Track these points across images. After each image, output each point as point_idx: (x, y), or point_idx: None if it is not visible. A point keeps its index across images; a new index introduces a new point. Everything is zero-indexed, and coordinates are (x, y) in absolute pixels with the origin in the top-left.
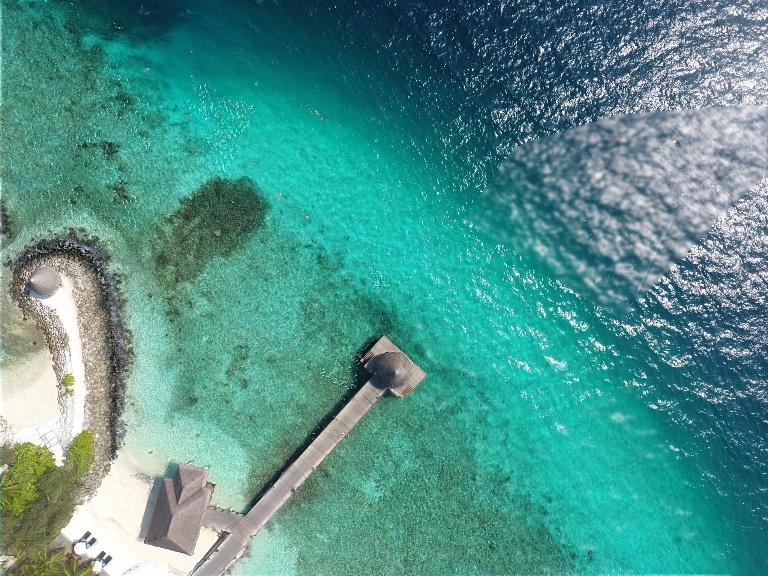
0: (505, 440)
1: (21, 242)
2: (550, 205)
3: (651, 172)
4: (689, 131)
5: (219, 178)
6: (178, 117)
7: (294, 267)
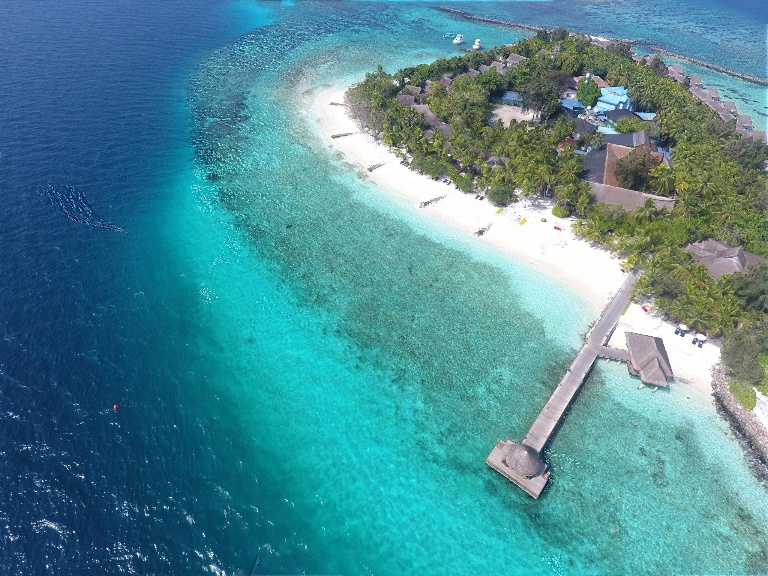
0: (398, 410)
1: None
2: None
3: None
4: None
5: None
6: None
7: (654, 575)
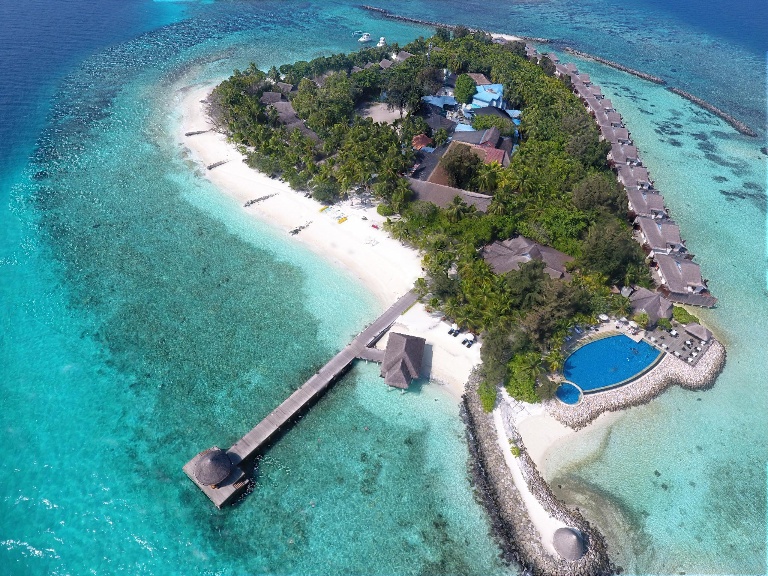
0: (123, 417)
1: None
2: None
3: None
4: None
5: None
6: None
7: None
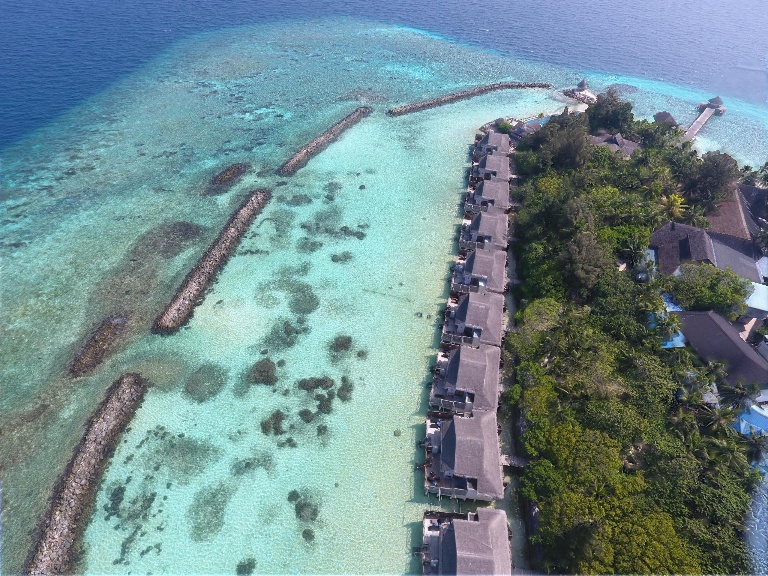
0: None
1: (561, 89)
2: (734, 85)
3: (763, 70)
4: (767, 58)
5: (616, 83)
6: (594, 76)
7: None
